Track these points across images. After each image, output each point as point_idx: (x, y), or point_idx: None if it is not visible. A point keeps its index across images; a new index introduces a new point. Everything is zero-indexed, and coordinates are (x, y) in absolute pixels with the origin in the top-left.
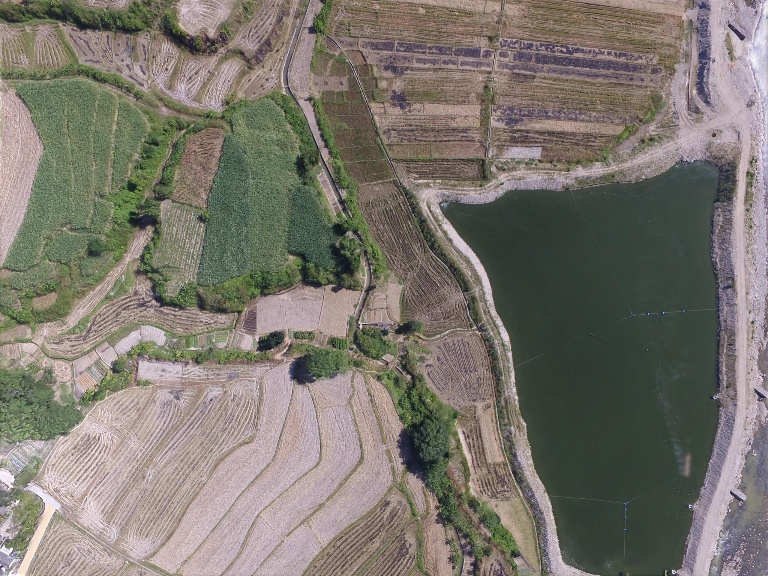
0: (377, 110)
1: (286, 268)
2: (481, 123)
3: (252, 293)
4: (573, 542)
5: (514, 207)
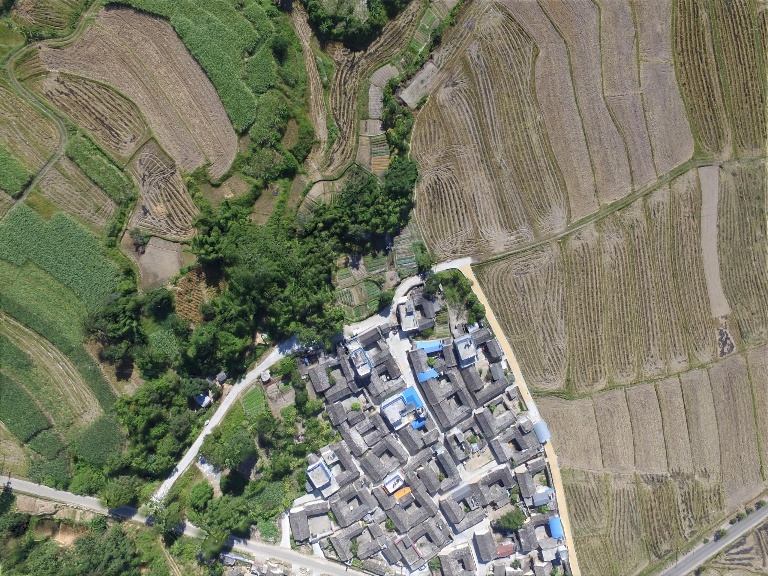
0: None
1: None
2: None
3: None
4: None
5: None
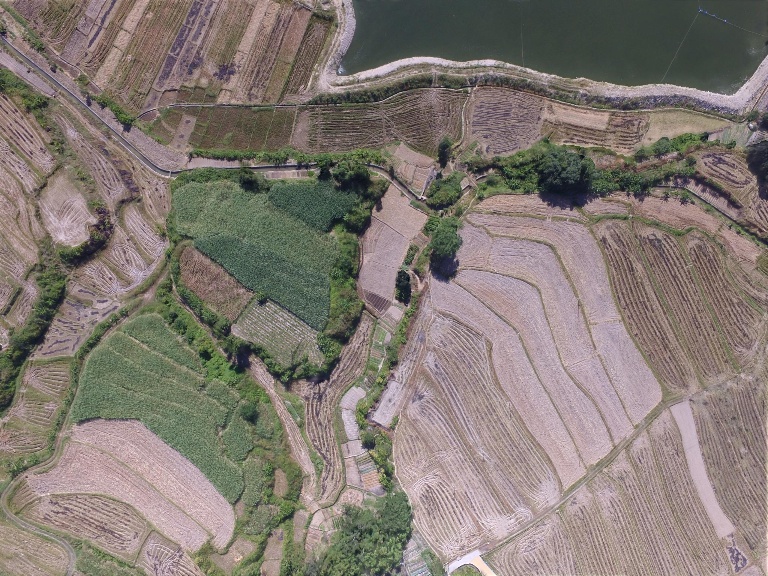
0: (226, 98)
1: (340, 242)
2: (277, 2)
3: (351, 285)
4: (716, 78)
5: (369, 4)
